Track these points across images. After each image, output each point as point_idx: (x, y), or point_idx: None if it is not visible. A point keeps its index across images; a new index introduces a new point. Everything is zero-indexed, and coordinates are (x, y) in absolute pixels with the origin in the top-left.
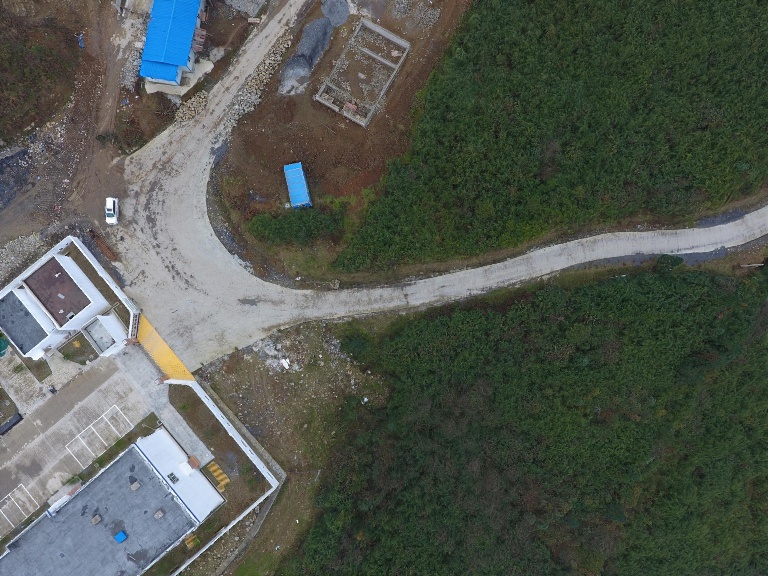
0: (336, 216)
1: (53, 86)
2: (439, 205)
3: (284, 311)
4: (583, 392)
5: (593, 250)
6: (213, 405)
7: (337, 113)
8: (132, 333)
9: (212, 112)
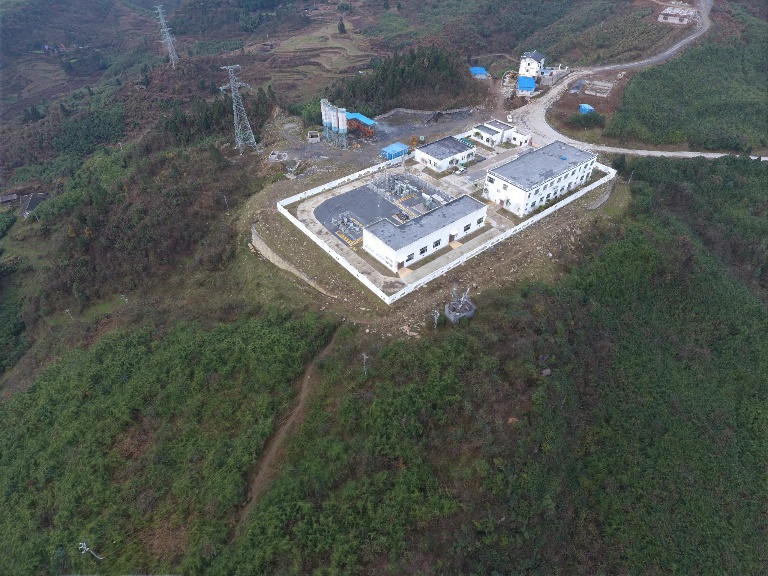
0: (602, 118)
1: (481, 97)
2: (639, 122)
3: (586, 147)
4: (738, 202)
5: (708, 155)
6: None
7: (594, 95)
8: None
9: None
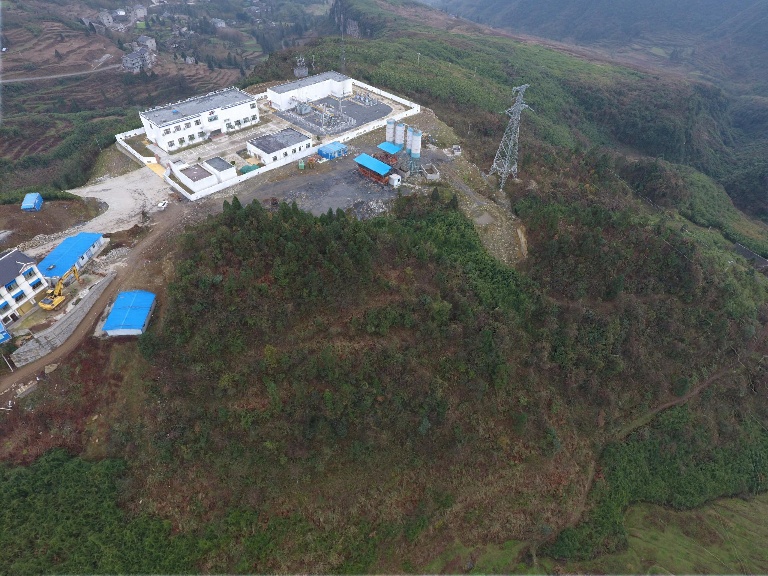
0: None
1: None
2: None
3: None
4: None
5: None
6: None
7: None
8: (168, 171)
9: None
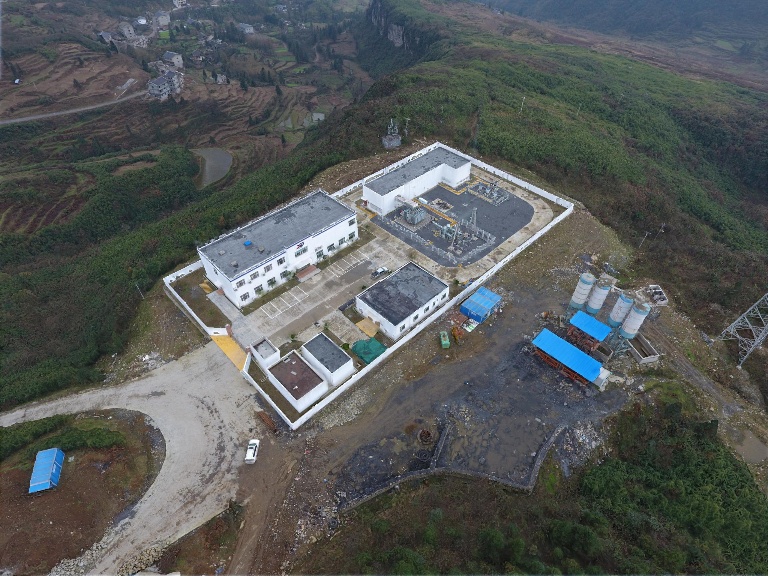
0: None
1: None
2: None
3: (131, 391)
4: None
5: None
6: None
7: None
8: None
9: (116, 560)
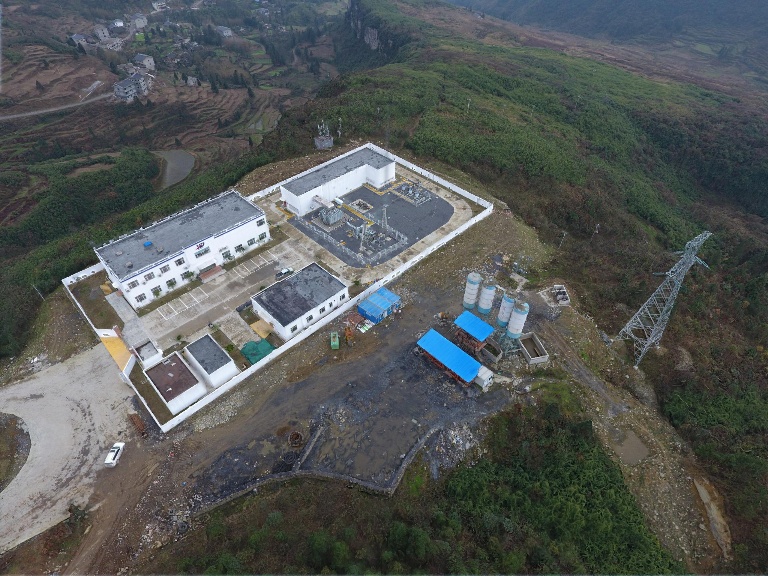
0: None
1: None
2: None
3: (11, 394)
4: None
5: None
6: (92, 323)
7: None
8: (132, 360)
9: None
